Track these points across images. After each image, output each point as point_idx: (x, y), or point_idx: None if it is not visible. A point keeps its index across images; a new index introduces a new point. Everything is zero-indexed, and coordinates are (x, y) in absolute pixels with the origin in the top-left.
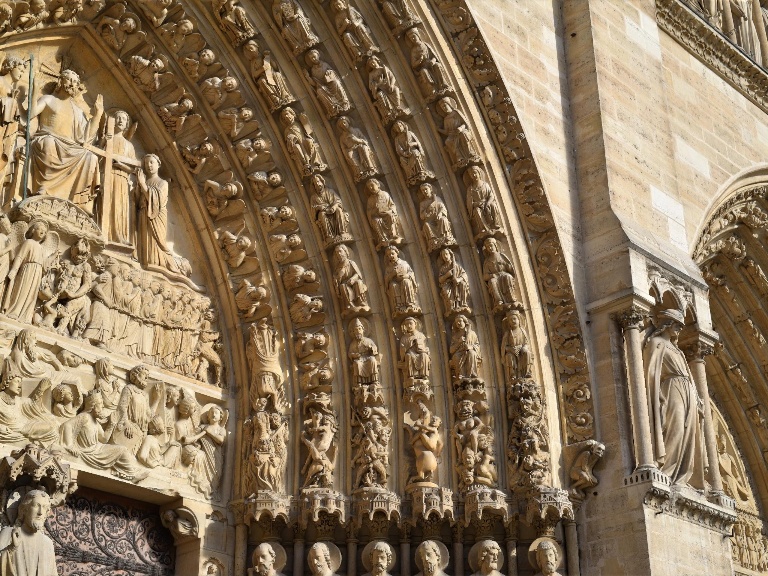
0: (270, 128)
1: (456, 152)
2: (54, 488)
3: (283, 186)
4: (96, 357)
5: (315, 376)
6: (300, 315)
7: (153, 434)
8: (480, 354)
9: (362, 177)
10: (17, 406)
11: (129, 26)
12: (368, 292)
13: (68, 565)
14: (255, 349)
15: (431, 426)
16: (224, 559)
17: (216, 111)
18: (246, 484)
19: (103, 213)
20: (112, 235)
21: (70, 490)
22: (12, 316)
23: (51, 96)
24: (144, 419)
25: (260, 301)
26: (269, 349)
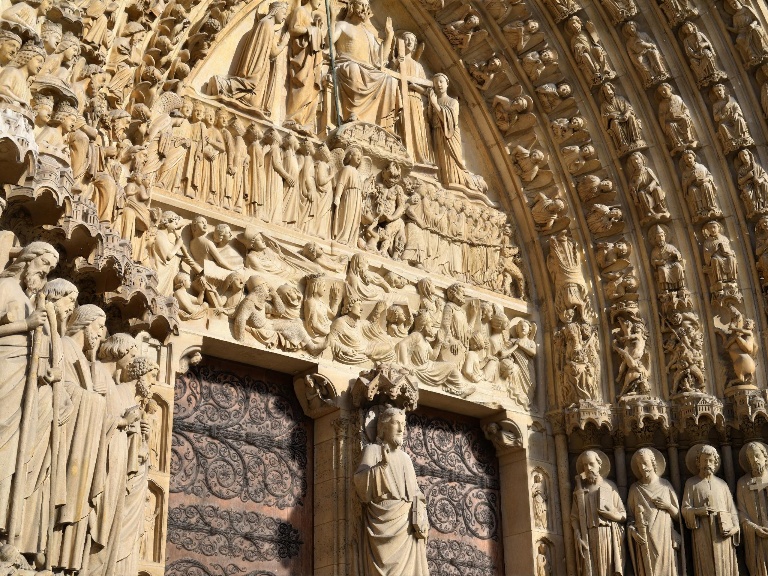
0: (555, 39)
1: (749, 50)
2: (402, 406)
3: (572, 97)
4: (417, 277)
5: (621, 285)
6: (599, 225)
7: (474, 350)
8: None
9: (653, 82)
10: (358, 329)
11: None
12: (666, 198)
13: None
14: (558, 261)
15: (746, 329)
16: (548, 468)
17: (500, 25)
18: (563, 394)
19: (406, 135)
20: (416, 157)
21: (408, 407)
22: (342, 242)
23: (345, 22)
24: (466, 335)
25: (557, 214)
26: (571, 261)
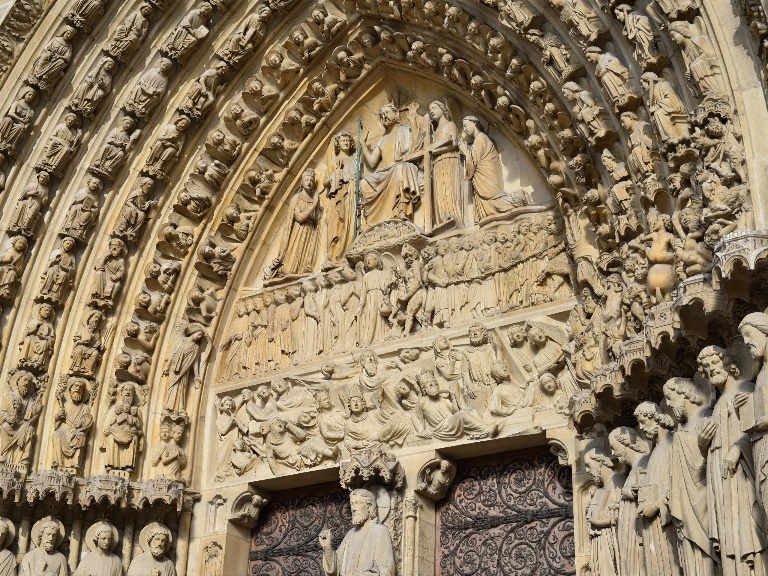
0: None
1: None
2: None
3: None
4: None
5: None
6: None
7: (501, 382)
8: (677, 105)
9: None
10: (370, 420)
11: (384, 39)
12: (608, 111)
13: (481, 535)
14: None
15: None
16: None
17: None
18: None
19: (425, 207)
20: None
21: (441, 469)
22: None
23: None
24: (485, 373)
25: None
26: None
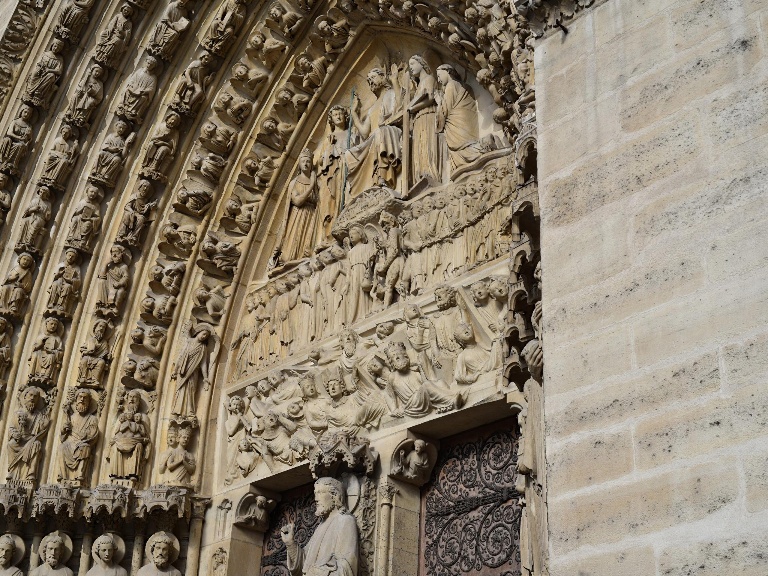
0: None
1: None
2: None
3: None
4: None
5: None
6: None
7: (466, 347)
8: None
9: None
10: (349, 403)
11: None
12: None
13: (461, 519)
14: None
15: None
16: None
17: None
18: None
19: (402, 169)
20: None
21: None
22: None
23: None
24: None
25: None
26: None
